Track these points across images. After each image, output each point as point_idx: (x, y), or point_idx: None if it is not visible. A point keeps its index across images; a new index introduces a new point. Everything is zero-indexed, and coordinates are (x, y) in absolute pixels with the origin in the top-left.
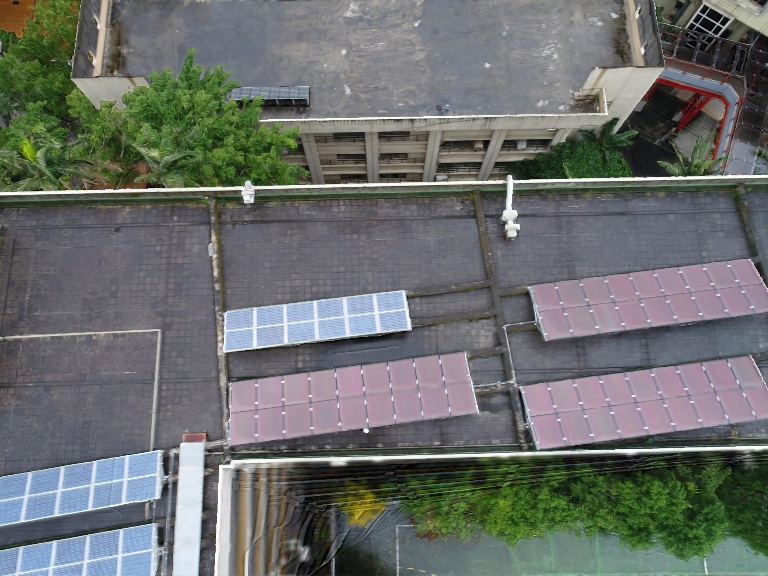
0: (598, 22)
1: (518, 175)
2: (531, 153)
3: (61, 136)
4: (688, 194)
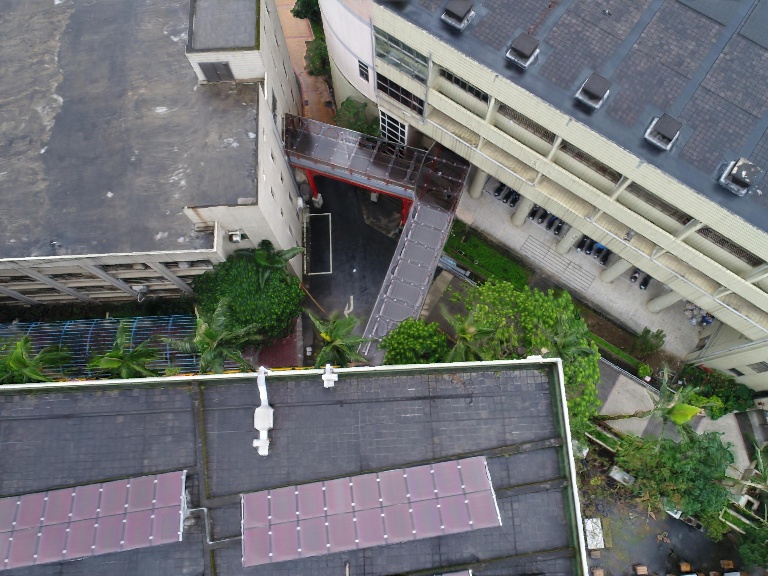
0: (233, 143)
1: (198, 290)
2: (205, 269)
3: None
4: (144, 391)
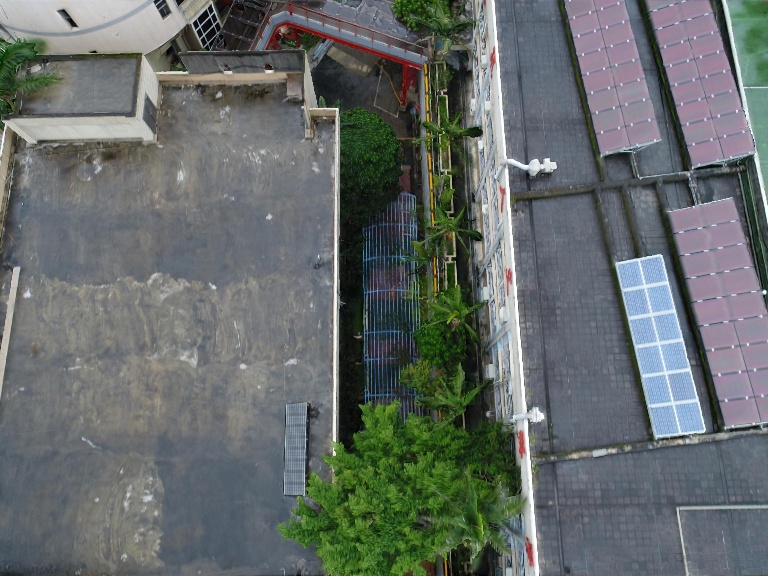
0: (226, 110)
1: (347, 212)
2: None
3: None
4: (498, 25)
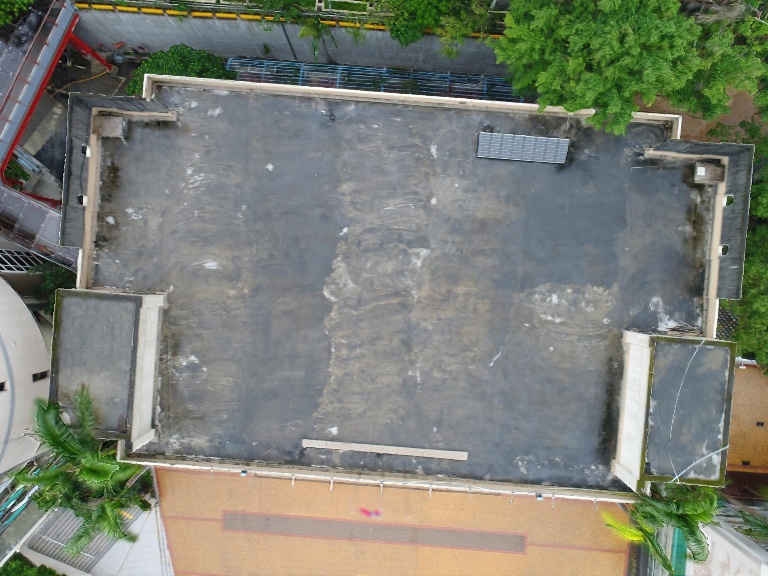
0: (132, 213)
1: None
2: None
3: (762, 94)
4: None
